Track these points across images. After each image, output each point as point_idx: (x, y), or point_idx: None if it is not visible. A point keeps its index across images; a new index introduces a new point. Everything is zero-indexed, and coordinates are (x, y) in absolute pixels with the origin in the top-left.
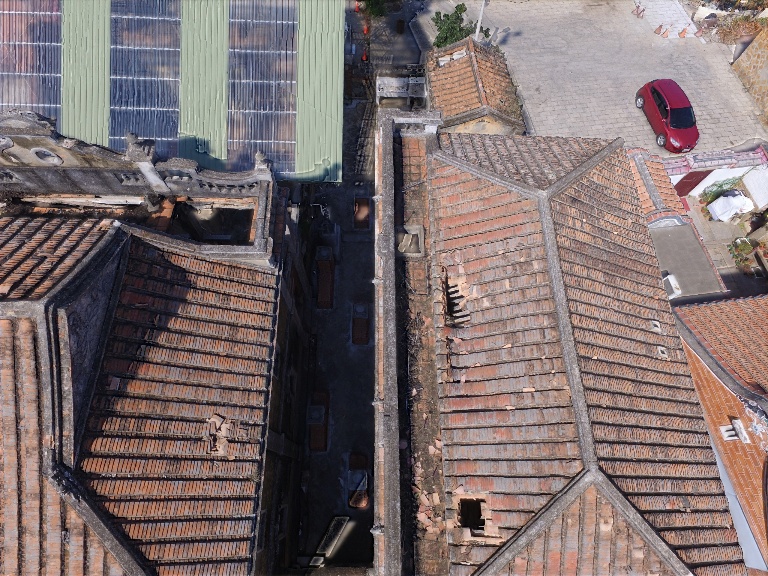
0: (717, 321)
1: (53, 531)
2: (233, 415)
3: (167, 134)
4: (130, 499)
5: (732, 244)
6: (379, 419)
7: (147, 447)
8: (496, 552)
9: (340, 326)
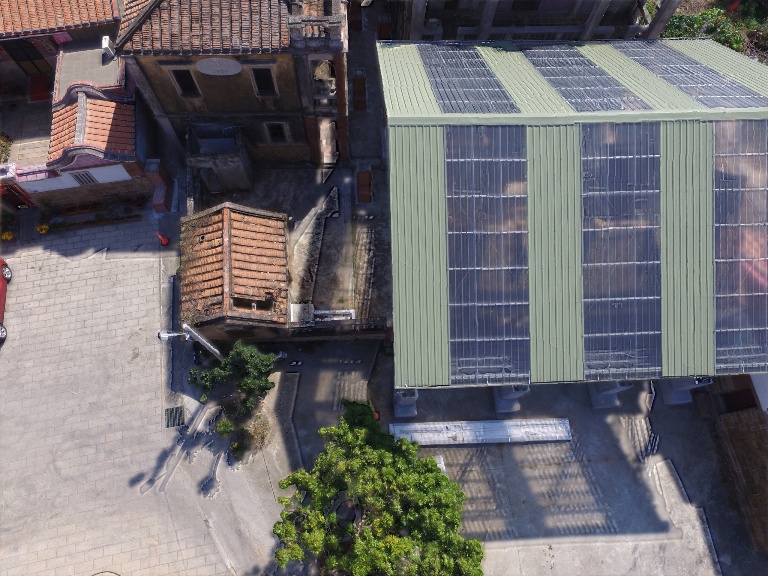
0: (91, 5)
1: None
2: None
3: (531, 52)
4: None
5: (1, 163)
6: None
7: None
8: None
9: (376, 96)
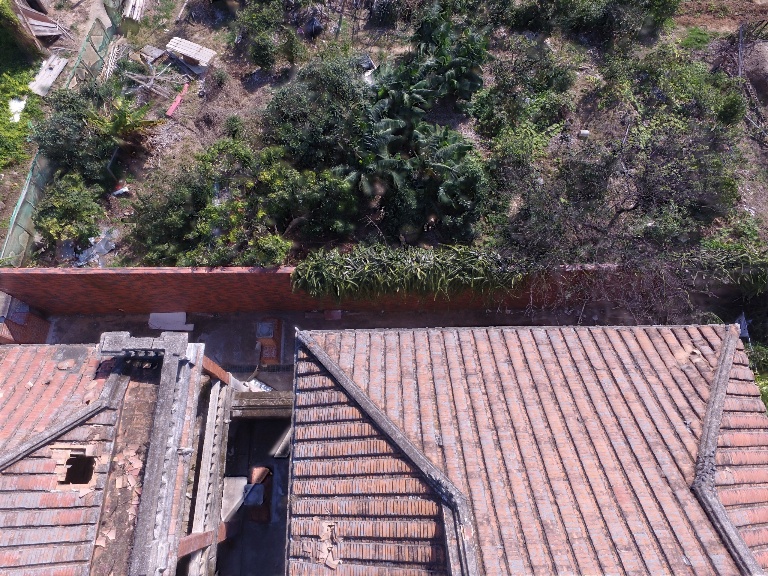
0: None
1: (450, 445)
2: (318, 569)
3: None
4: (393, 475)
5: None
6: (153, 571)
7: (389, 528)
8: (59, 436)
9: None
